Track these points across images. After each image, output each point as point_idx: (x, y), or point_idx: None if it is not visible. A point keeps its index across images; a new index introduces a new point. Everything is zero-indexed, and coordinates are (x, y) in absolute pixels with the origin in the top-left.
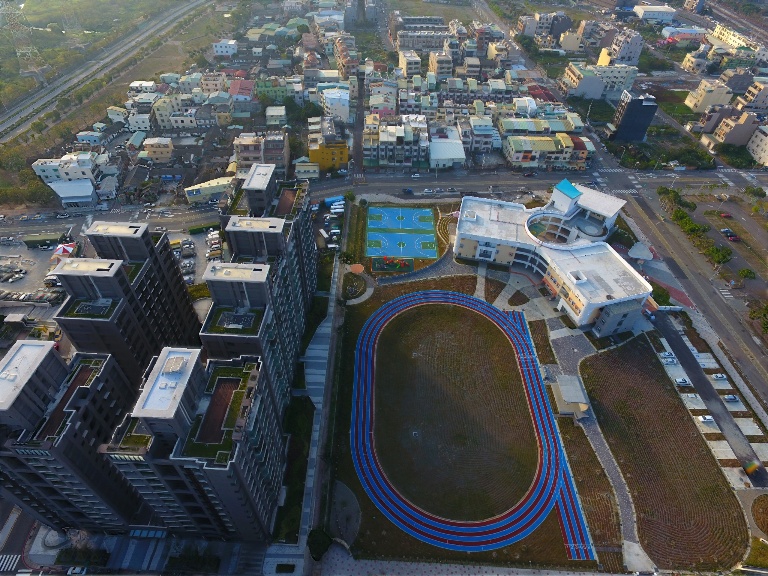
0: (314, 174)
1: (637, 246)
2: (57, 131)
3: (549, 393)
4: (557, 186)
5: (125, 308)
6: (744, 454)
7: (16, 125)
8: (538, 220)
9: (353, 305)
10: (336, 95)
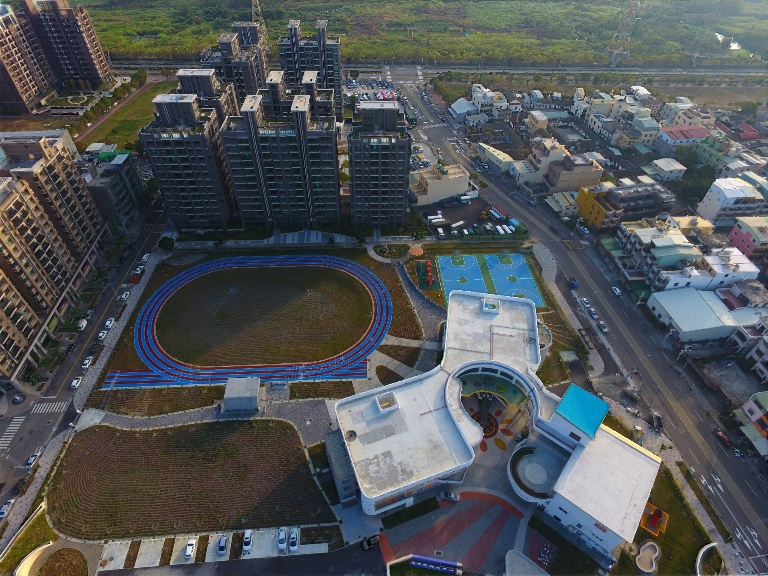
0: (558, 208)
1: (540, 574)
2: (538, 85)
3: None
4: (576, 387)
5: (270, 107)
6: None
7: (542, 74)
8: (528, 393)
9: (366, 251)
10: (727, 186)
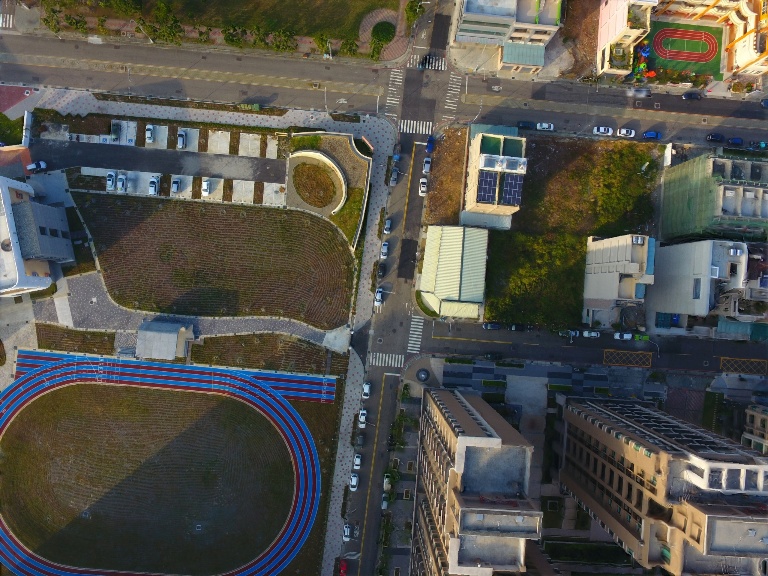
0: None
1: None
2: None
3: (157, 359)
4: None
5: None
6: (250, 171)
7: None
8: None
9: None
10: None
